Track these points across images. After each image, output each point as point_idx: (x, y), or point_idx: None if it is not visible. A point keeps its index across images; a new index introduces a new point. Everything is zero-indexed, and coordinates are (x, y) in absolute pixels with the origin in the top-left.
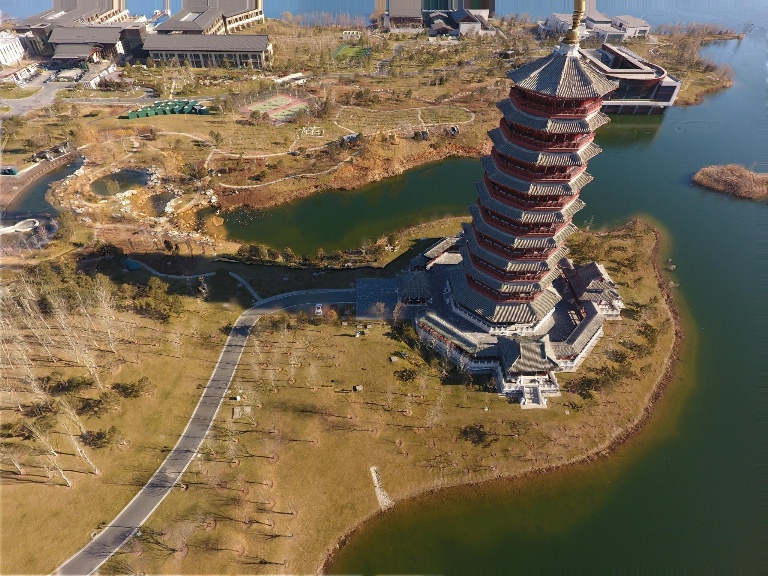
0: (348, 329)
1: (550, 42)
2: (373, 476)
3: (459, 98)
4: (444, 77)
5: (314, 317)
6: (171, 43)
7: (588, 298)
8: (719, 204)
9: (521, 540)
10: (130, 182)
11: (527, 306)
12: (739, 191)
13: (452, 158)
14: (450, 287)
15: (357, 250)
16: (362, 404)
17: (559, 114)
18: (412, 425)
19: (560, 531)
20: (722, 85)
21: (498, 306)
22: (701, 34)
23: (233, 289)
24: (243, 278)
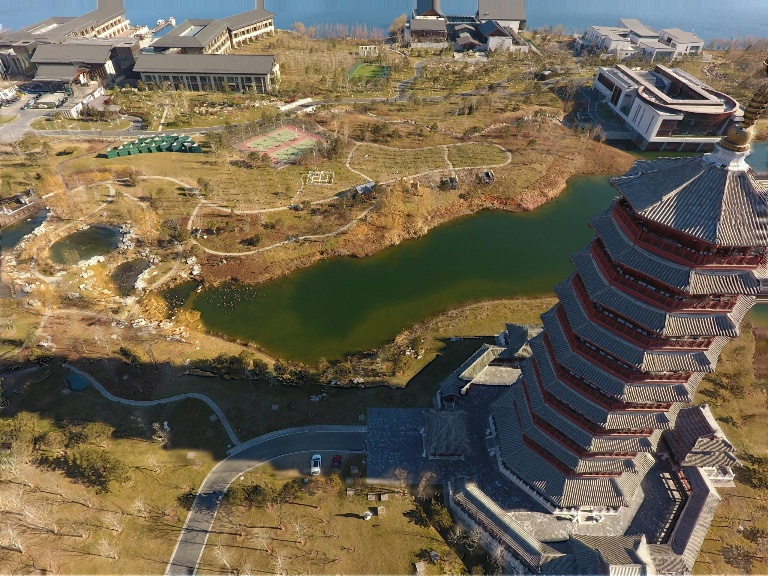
0: (355, 503)
1: (593, 62)
2: None
3: (492, 132)
4: (474, 106)
5: (309, 478)
6: (165, 64)
7: (692, 462)
8: None
9: None
10: (98, 244)
11: (609, 480)
12: None
13: (486, 211)
14: (495, 430)
15: (370, 352)
16: None
17: (710, 264)
18: None
19: None
20: None
21: (568, 480)
22: (764, 52)
23: (203, 425)
24: (218, 405)
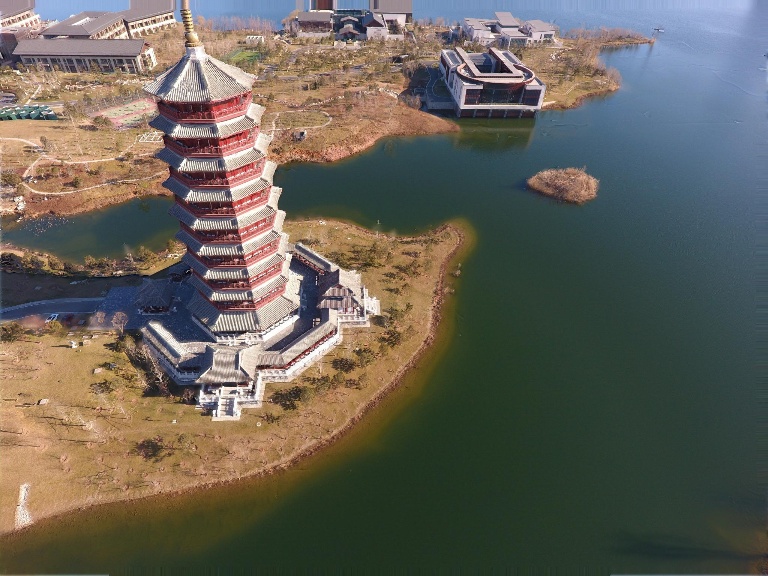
0: (71, 340)
1: (444, 46)
2: (20, 494)
3: (326, 102)
4: (316, 81)
5: (43, 327)
6: (43, 48)
7: (327, 305)
8: (553, 208)
9: (153, 560)
10: None
11: (253, 314)
12: (566, 195)
13: (295, 163)
14: None
15: None
16: (39, 418)
17: (185, 119)
18: (86, 440)
19: (197, 549)
20: (608, 89)
21: (222, 315)
22: (602, 38)
23: None
24: None
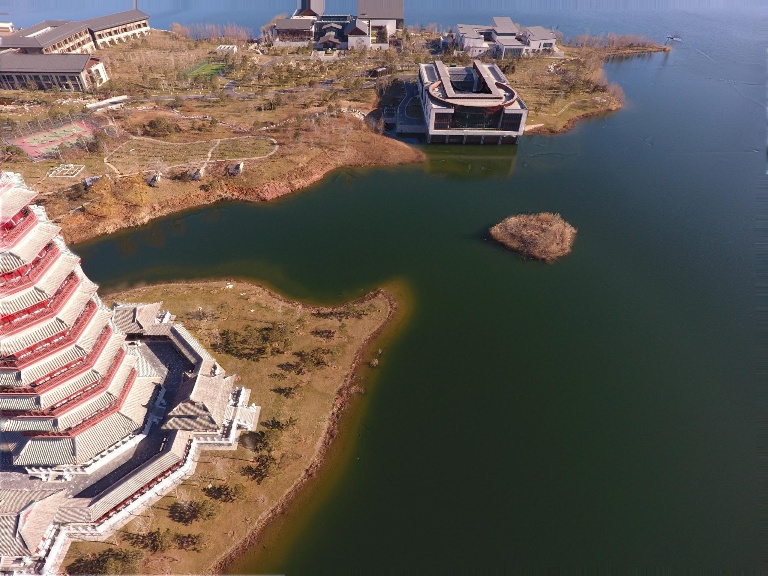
0: None
1: (426, 58)
2: None
3: None
4: (271, 101)
5: None
6: None
7: (175, 426)
8: (519, 263)
9: None
10: None
11: (72, 441)
12: (532, 250)
13: (225, 202)
14: None
15: None
16: None
17: None
18: None
19: None
20: (607, 108)
21: (32, 441)
22: (608, 48)
23: None
24: None
